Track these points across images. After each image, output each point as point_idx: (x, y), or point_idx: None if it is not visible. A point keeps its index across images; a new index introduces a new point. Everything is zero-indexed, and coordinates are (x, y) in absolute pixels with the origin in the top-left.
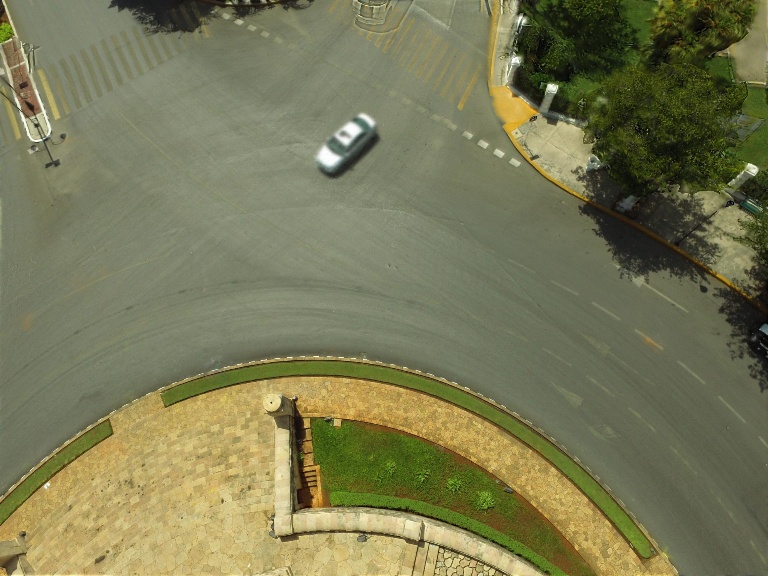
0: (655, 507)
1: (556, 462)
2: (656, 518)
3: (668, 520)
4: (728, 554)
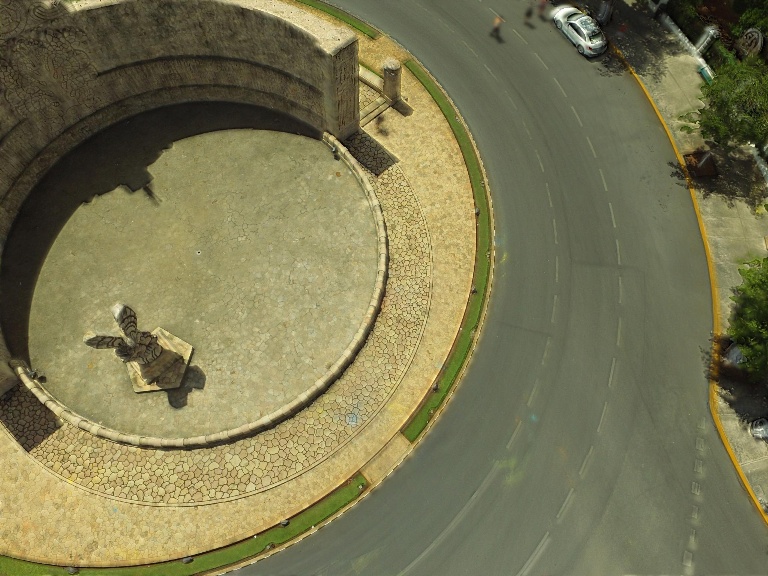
0: (379, 15)
1: (313, 4)
2: (381, 20)
3: (388, 19)
4: (426, 28)
